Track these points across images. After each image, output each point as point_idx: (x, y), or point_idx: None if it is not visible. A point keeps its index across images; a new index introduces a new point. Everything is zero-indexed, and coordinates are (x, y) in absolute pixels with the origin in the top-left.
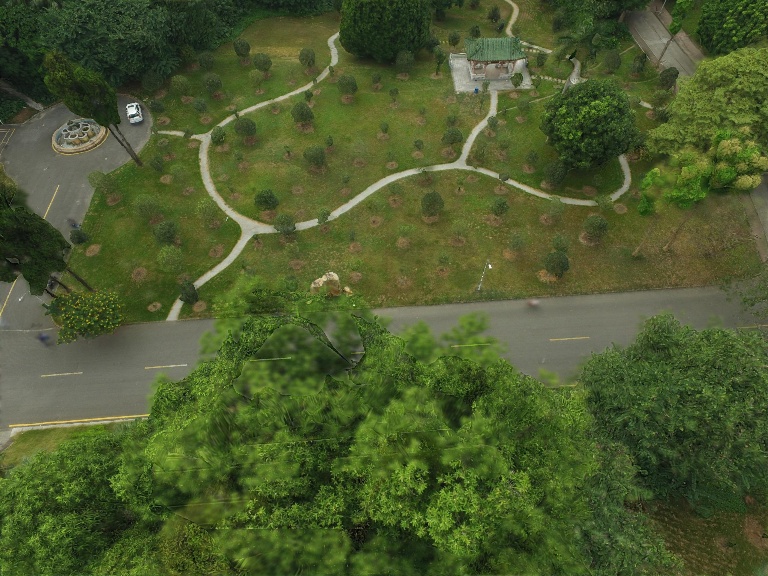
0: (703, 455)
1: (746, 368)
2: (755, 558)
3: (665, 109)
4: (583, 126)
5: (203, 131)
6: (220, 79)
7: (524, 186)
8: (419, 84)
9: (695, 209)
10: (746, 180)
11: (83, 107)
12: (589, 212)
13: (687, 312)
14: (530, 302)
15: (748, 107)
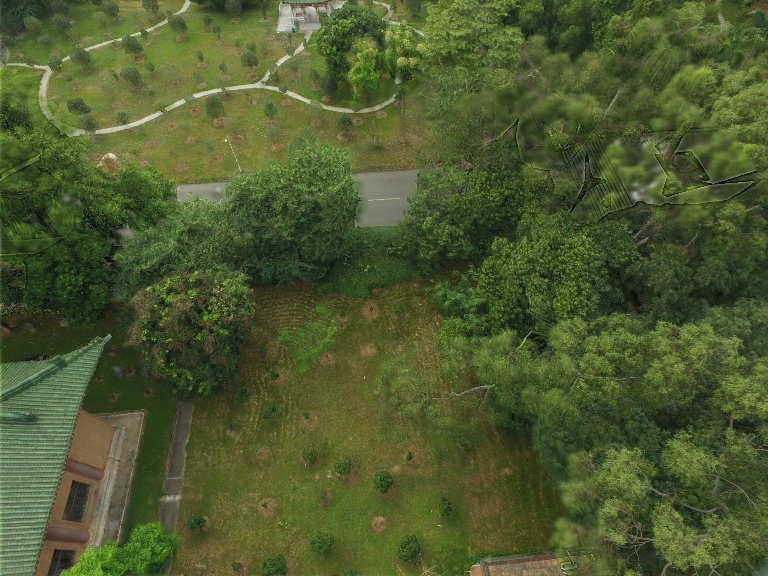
0: (275, 222)
1: None
2: (362, 324)
3: None
4: (336, 42)
5: None
6: (76, 24)
7: (308, 100)
8: (247, 26)
9: None
10: (400, 60)
11: None
12: (354, 117)
13: (406, 185)
14: None
15: (465, 23)
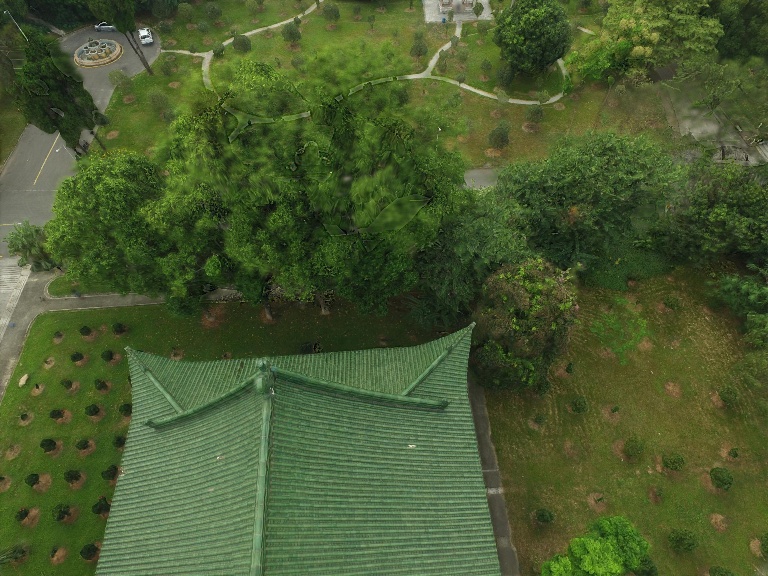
0: (576, 211)
1: (606, 145)
2: (629, 317)
3: None
4: (525, 31)
5: (205, 50)
6: None
7: (479, 91)
8: (394, 16)
9: (622, 107)
10: (639, 49)
11: (106, 10)
12: None
13: None
14: (477, 171)
15: (661, 14)
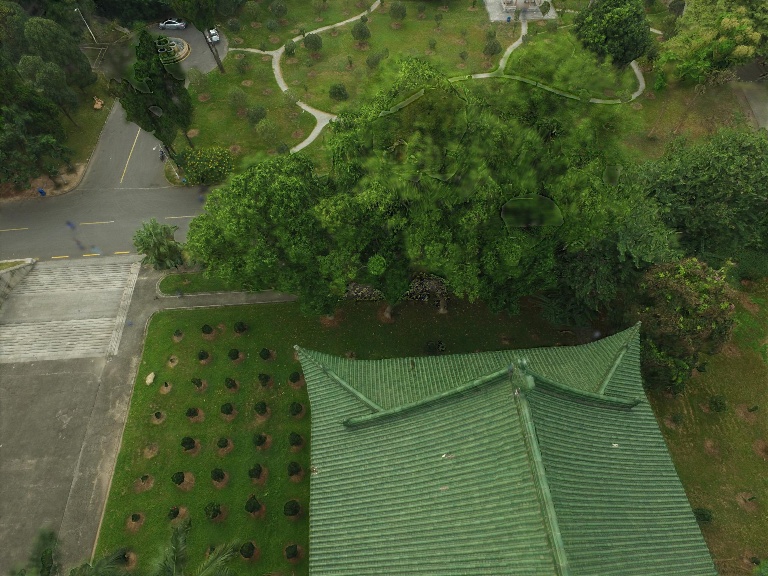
0: (710, 210)
1: (742, 144)
2: None
3: (674, 27)
4: (607, 30)
5: (273, 48)
6: None
7: (554, 90)
8: (458, 14)
9: (700, 106)
10: (743, 48)
11: (190, 8)
12: None
13: None
14: None
15: (745, 13)
